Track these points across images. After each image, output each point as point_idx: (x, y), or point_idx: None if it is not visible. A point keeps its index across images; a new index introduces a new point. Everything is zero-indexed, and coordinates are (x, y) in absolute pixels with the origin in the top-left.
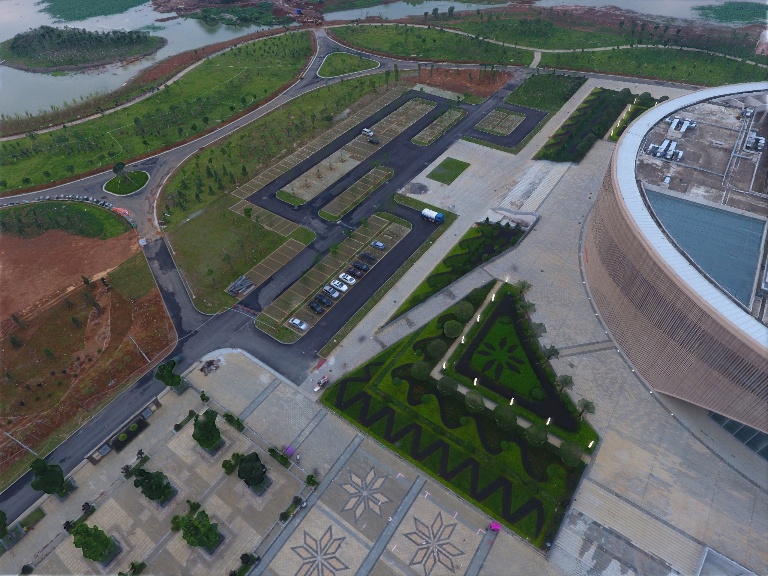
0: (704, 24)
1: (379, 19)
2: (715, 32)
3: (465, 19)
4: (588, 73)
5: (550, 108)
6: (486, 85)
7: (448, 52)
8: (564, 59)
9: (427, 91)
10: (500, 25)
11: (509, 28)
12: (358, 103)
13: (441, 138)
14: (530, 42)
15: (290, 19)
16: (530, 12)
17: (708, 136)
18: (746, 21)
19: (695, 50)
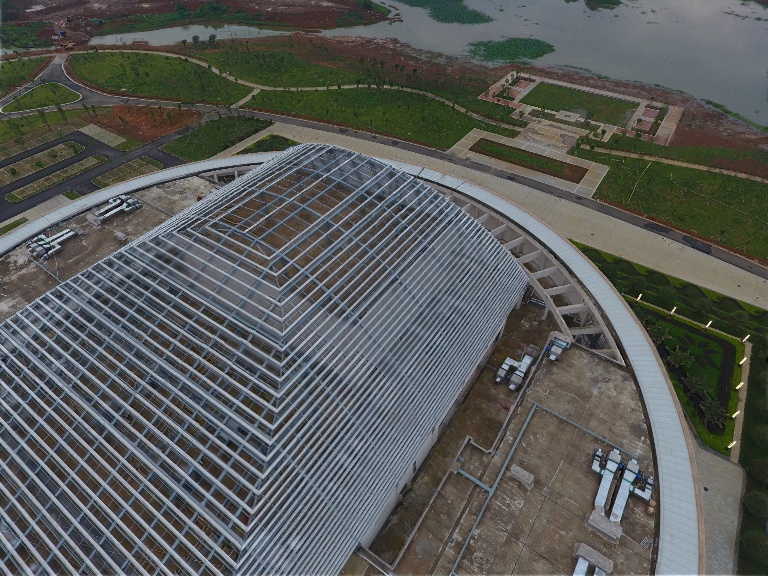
0: (464, 62)
1: (142, 45)
2: (465, 72)
3: (223, 48)
4: (282, 116)
5: (198, 158)
6: (161, 127)
7: (162, 87)
8: (273, 99)
9: (91, 133)
10: (247, 57)
11: (251, 61)
12: (2, 146)
13: (42, 192)
14: (260, 78)
15: (49, 42)
16: (301, 43)
17: (132, 223)
18: (508, 60)
19: (419, 92)
